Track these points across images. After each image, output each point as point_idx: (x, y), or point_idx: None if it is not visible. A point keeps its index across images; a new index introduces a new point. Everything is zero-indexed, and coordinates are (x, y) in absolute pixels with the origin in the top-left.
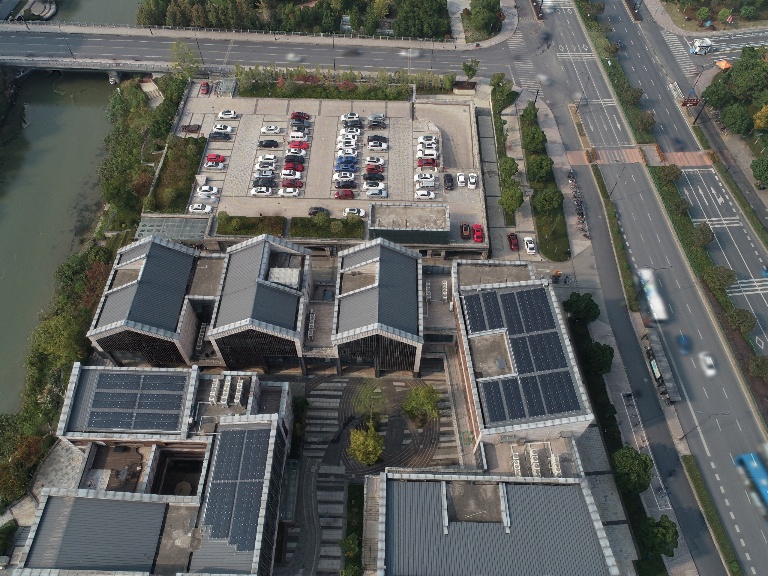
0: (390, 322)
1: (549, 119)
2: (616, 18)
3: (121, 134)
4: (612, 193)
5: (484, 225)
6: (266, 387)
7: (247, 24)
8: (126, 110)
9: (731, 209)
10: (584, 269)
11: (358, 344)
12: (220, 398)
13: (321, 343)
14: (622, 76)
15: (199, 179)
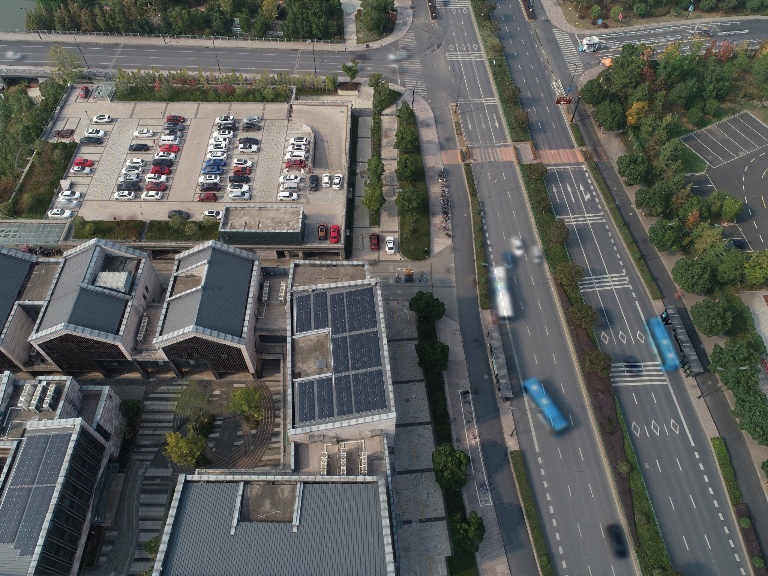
0: (210, 324)
1: (428, 119)
2: (510, 17)
3: None
4: (481, 191)
5: (342, 225)
6: (87, 391)
7: (135, 28)
8: (9, 116)
9: (596, 205)
10: (441, 268)
11: (182, 347)
12: None
13: (152, 346)
14: (507, 75)
15: (63, 184)
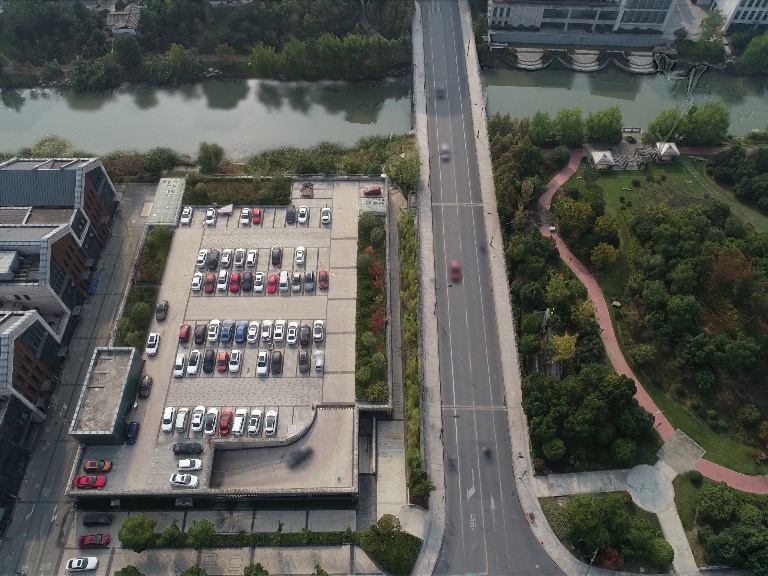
0: None
1: None
2: None
3: None
4: None
5: None
6: None
7: None
8: None
9: None
10: None
11: None
12: None
13: None
14: None
15: (226, 207)
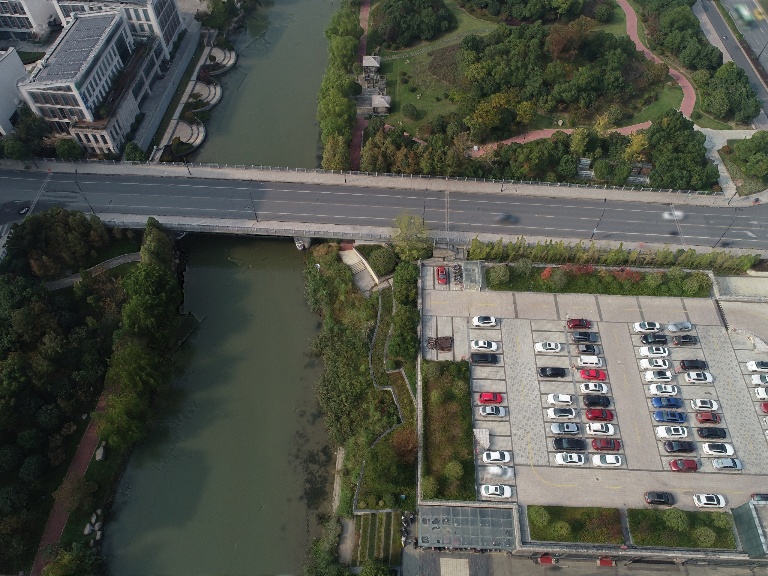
0: None
1: None
2: None
3: (335, 336)
4: None
5: None
6: None
7: (468, 173)
8: (330, 294)
9: None
10: None
11: None
12: None
13: None
14: None
15: (480, 437)
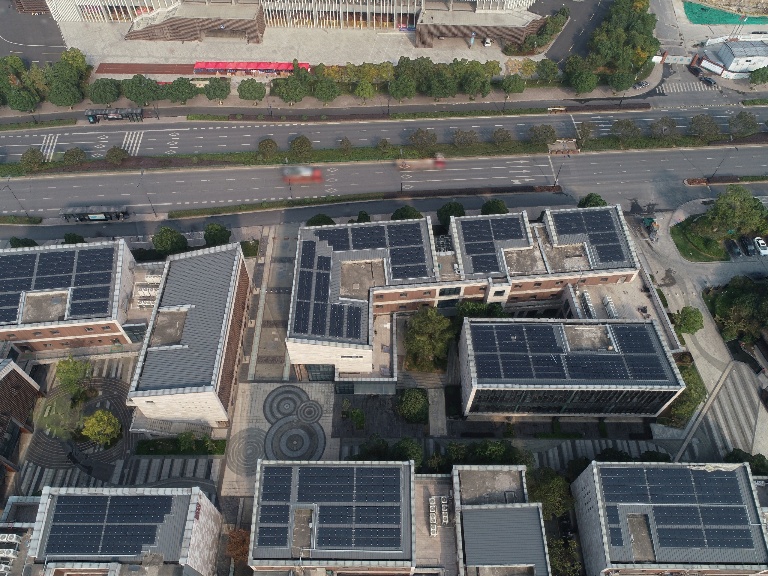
0: None
1: None
2: None
3: None
4: None
5: None
6: None
7: None
8: None
9: None
10: None
11: None
12: (4, 563)
13: None
14: None
15: None
